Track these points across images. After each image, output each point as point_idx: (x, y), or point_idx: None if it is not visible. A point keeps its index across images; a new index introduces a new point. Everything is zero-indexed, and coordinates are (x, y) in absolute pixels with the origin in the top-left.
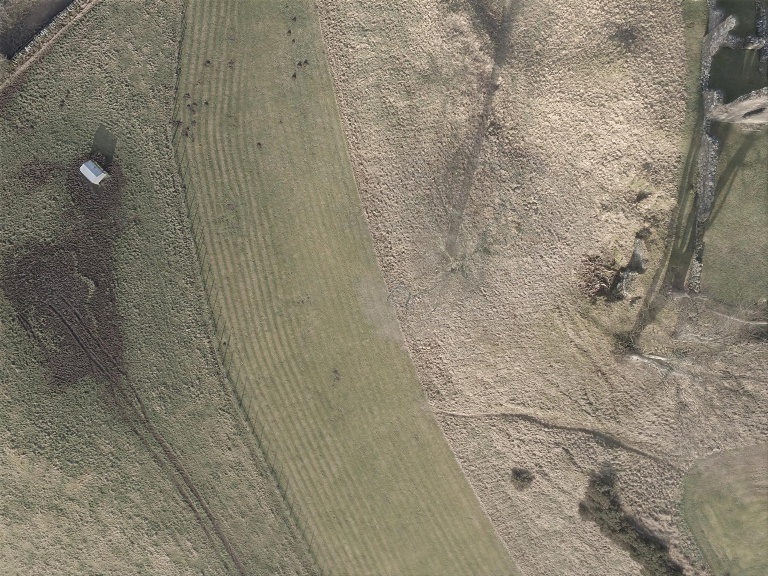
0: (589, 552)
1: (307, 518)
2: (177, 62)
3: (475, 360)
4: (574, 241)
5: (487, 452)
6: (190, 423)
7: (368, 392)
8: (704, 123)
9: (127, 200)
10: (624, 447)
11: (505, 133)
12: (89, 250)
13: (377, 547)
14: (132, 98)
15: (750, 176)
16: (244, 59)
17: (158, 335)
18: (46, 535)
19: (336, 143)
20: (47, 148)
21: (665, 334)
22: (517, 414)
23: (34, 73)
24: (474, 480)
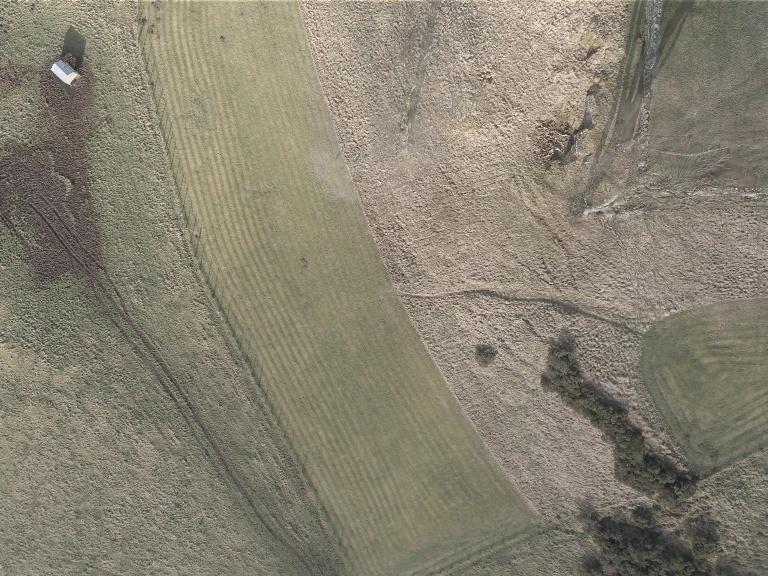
0: (552, 424)
1: (282, 404)
2: None
3: (436, 238)
4: (527, 107)
5: (452, 331)
6: (167, 314)
7: (335, 278)
8: None
9: (98, 99)
10: (582, 312)
11: (458, 4)
12: (64, 150)
13: (349, 431)
14: None
15: (699, 22)
16: None
17: (133, 230)
18: (38, 426)
19: (296, 32)
20: (20, 52)
21: (617, 192)
22: (478, 290)
23: None
24: (440, 360)
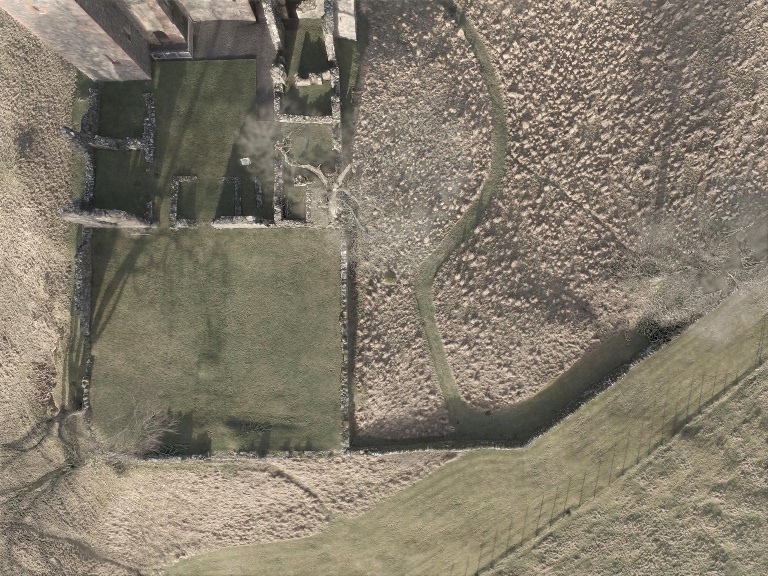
0: None
1: None
2: None
3: None
4: (21, 349)
5: (8, 560)
6: None
7: None
8: (82, 232)
9: None
10: (97, 558)
11: None
12: None
13: None
14: None
15: (143, 282)
16: None
17: None
18: None
19: None
20: None
21: None
22: (19, 523)
23: None
24: None
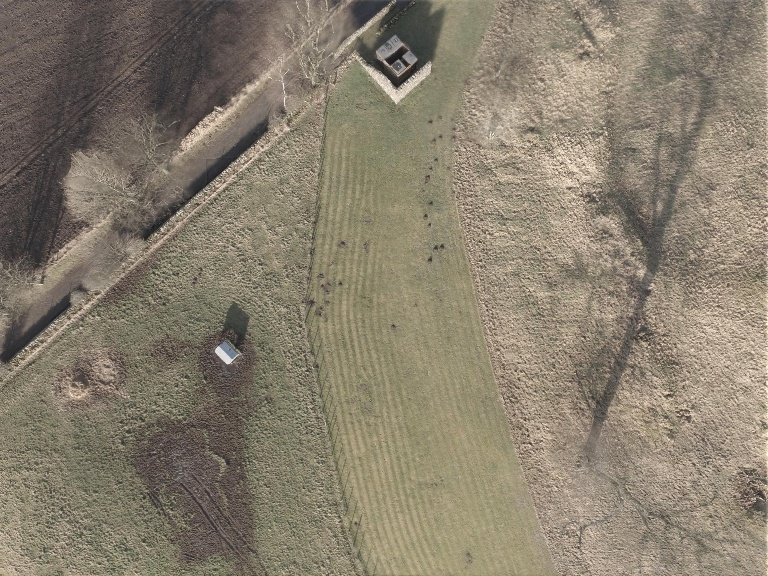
0: None
1: None
2: (311, 242)
3: (617, 555)
4: (730, 453)
5: None
6: None
7: (501, 575)
8: None
9: (259, 378)
10: None
11: (657, 339)
12: (220, 428)
13: None
14: (265, 277)
15: None
16: (379, 241)
17: (289, 514)
18: None
19: (472, 327)
20: (179, 326)
21: None
22: None
23: (167, 251)
24: None
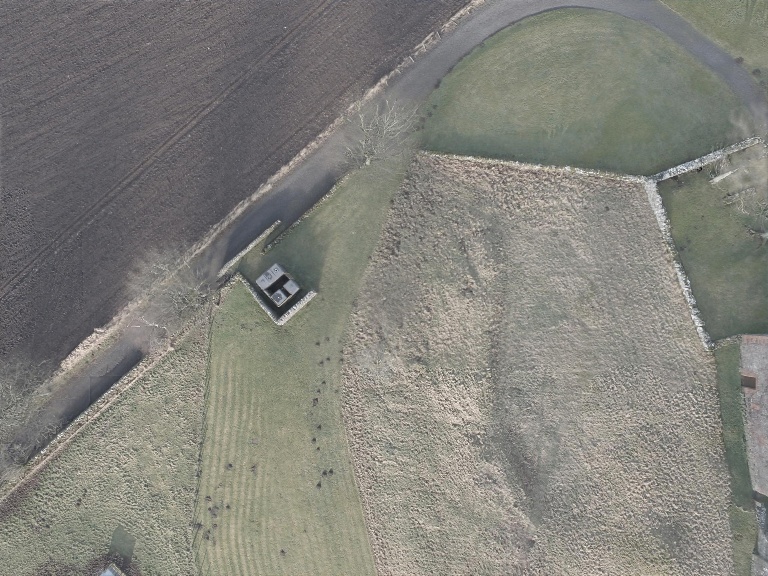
0: None
1: None
2: (198, 464)
3: None
4: None
5: None
6: None
7: None
8: None
9: None
10: None
11: None
12: None
13: None
14: (151, 498)
15: None
16: (267, 464)
17: None
18: None
19: (362, 555)
20: (63, 549)
21: None
22: None
23: (50, 472)
24: None
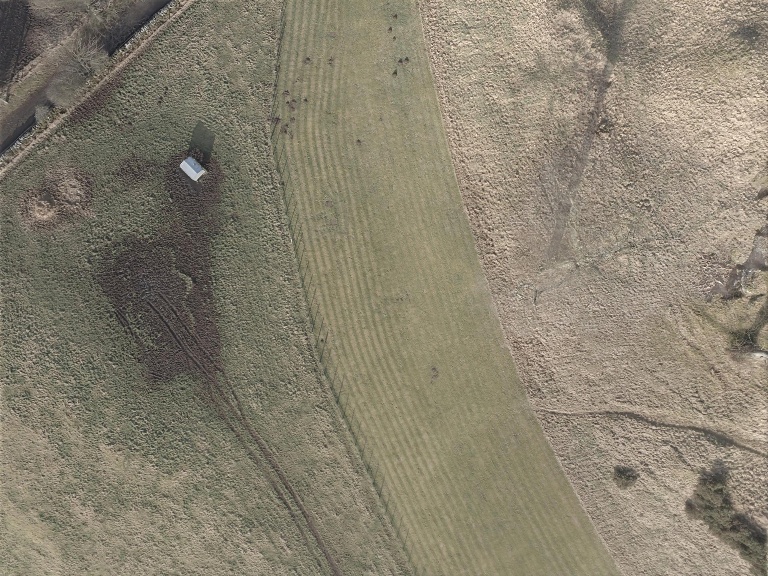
0: (694, 551)
1: (402, 516)
2: (276, 59)
3: (580, 358)
4: (689, 238)
5: (589, 450)
6: (286, 420)
7: (467, 390)
8: None
9: (225, 197)
10: (737, 445)
11: (617, 130)
12: (187, 247)
13: (472, 545)
14: (231, 95)
15: None
16: (344, 56)
17: (255, 332)
18: (139, 532)
19: (437, 140)
20: (145, 145)
21: None
22: (622, 412)
23: (133, 70)
24: (574, 478)
